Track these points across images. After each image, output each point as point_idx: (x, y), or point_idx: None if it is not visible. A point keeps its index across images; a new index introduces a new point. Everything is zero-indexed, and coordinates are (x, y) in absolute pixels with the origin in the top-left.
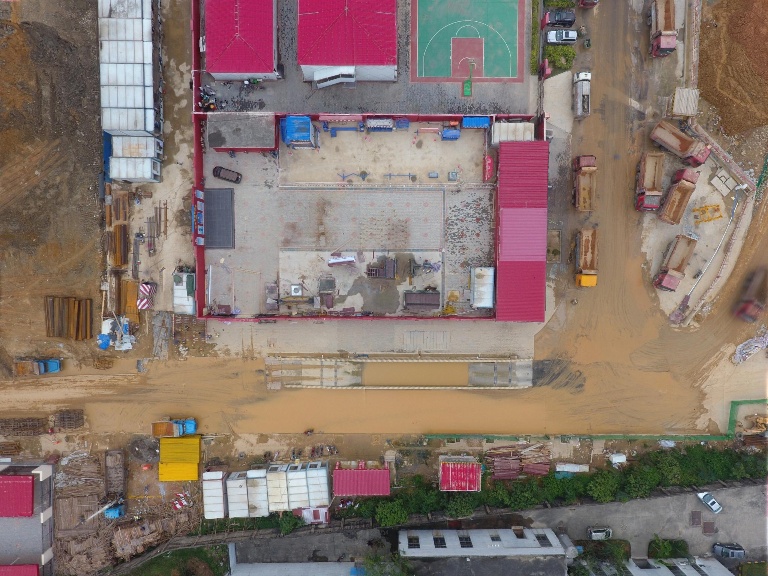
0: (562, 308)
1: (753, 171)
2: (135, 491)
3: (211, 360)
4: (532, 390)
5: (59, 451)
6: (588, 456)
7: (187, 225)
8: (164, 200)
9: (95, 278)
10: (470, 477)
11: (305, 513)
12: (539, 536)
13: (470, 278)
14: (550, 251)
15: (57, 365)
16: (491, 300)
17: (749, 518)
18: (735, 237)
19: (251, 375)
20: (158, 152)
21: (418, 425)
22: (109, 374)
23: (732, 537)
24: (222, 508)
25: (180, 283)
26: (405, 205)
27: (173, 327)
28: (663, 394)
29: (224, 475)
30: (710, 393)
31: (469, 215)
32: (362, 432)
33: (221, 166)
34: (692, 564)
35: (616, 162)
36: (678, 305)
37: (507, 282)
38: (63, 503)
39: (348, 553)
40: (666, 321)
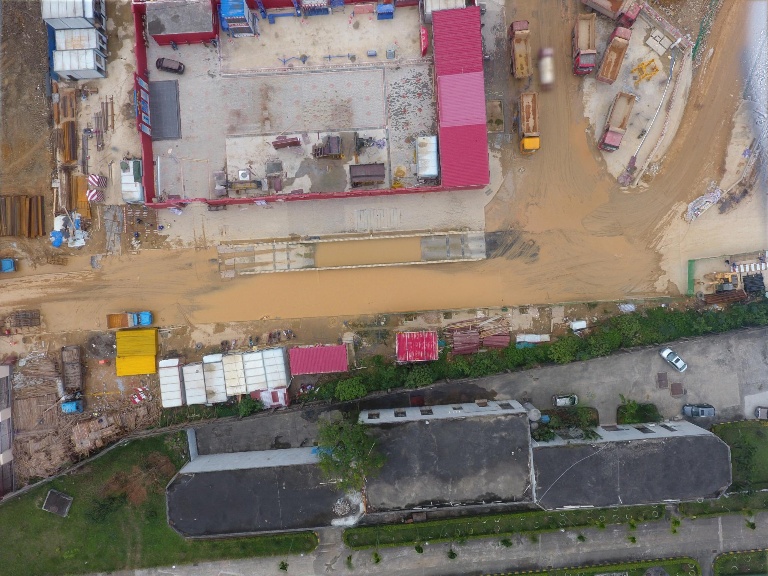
0: (510, 178)
1: (690, 36)
2: (94, 388)
3: (164, 252)
4: (486, 262)
5: (17, 353)
6: (548, 326)
7: (134, 118)
8: (110, 95)
9: (46, 175)
10: (427, 346)
11: (263, 395)
12: (502, 404)
13: (415, 152)
14: (493, 121)
15: (11, 263)
16: (436, 168)
17: (717, 377)
18: (675, 94)
19: (205, 265)
20: (101, 45)
21: (374, 305)
22: (64, 272)
23: (702, 398)
24: (179, 395)
25: (127, 170)
26: (346, 85)
27: (125, 220)
28: (619, 258)
29: (181, 364)
30: (666, 254)
31: (410, 91)
32: (319, 315)
33: (164, 58)
34: (662, 425)
35: (551, 31)
36: (625, 167)
37: (450, 148)
38: (21, 403)
39: (311, 438)
40: (615, 184)
